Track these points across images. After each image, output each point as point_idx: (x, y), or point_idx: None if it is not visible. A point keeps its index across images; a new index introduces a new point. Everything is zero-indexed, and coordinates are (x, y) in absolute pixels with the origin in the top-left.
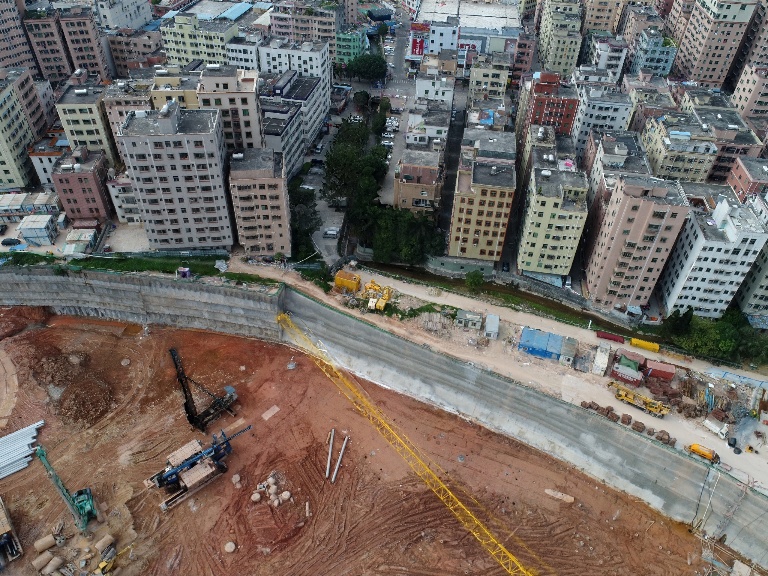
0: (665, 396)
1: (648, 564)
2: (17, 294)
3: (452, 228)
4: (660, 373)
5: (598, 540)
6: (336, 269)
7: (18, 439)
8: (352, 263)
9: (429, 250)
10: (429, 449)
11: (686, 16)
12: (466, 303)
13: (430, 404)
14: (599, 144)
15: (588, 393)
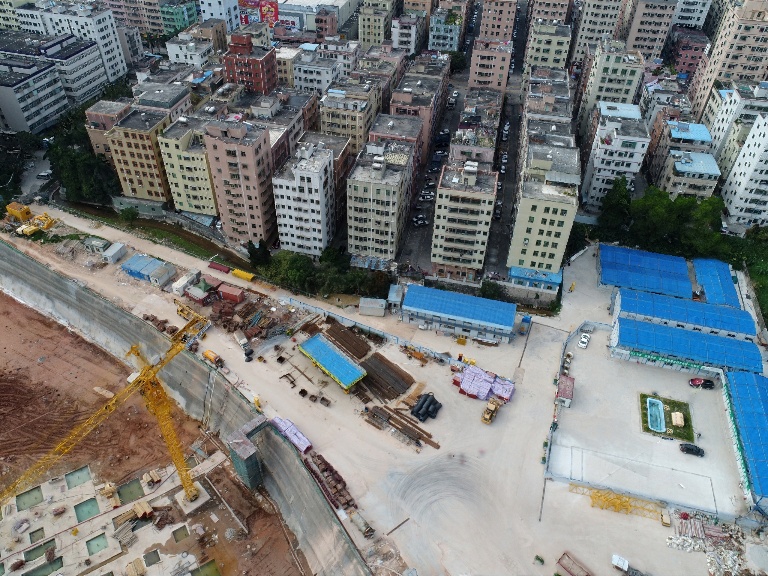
0: (219, 314)
1: (138, 447)
2: None
3: (117, 169)
4: (228, 296)
5: (109, 427)
6: (25, 203)
7: None
8: (36, 198)
9: (107, 190)
10: (18, 350)
11: None
12: (116, 235)
13: (49, 317)
14: None
15: (158, 309)
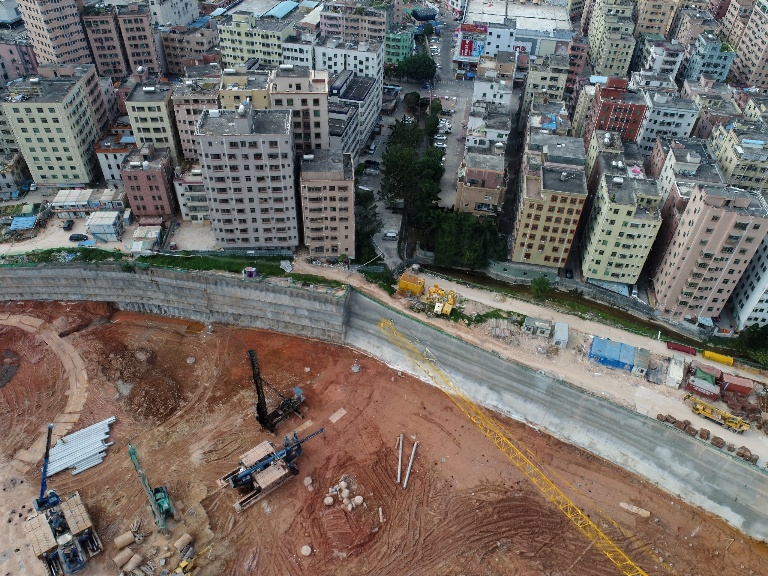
0: (744, 411)
1: None
2: (83, 289)
3: (518, 234)
4: (737, 387)
5: (677, 557)
6: (398, 272)
7: (91, 434)
8: (415, 266)
9: (492, 255)
10: (499, 457)
11: (743, 20)
12: (532, 310)
13: (497, 411)
14: (669, 151)
15: (663, 406)
